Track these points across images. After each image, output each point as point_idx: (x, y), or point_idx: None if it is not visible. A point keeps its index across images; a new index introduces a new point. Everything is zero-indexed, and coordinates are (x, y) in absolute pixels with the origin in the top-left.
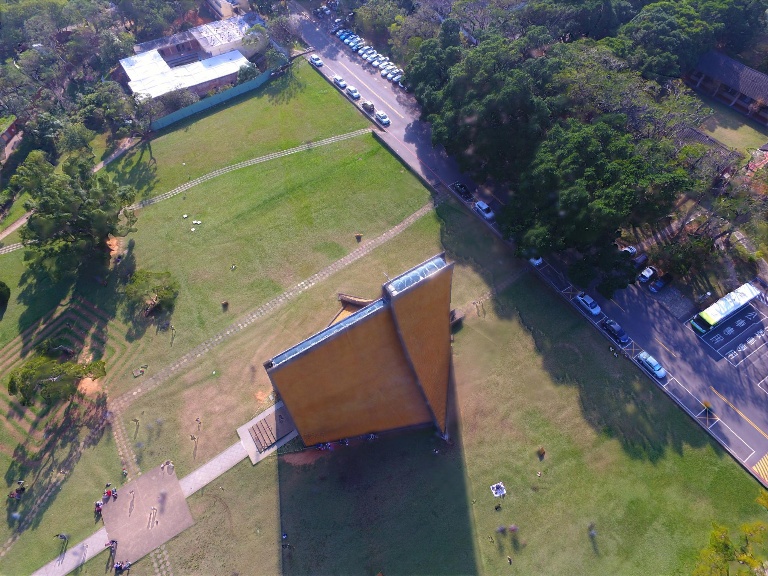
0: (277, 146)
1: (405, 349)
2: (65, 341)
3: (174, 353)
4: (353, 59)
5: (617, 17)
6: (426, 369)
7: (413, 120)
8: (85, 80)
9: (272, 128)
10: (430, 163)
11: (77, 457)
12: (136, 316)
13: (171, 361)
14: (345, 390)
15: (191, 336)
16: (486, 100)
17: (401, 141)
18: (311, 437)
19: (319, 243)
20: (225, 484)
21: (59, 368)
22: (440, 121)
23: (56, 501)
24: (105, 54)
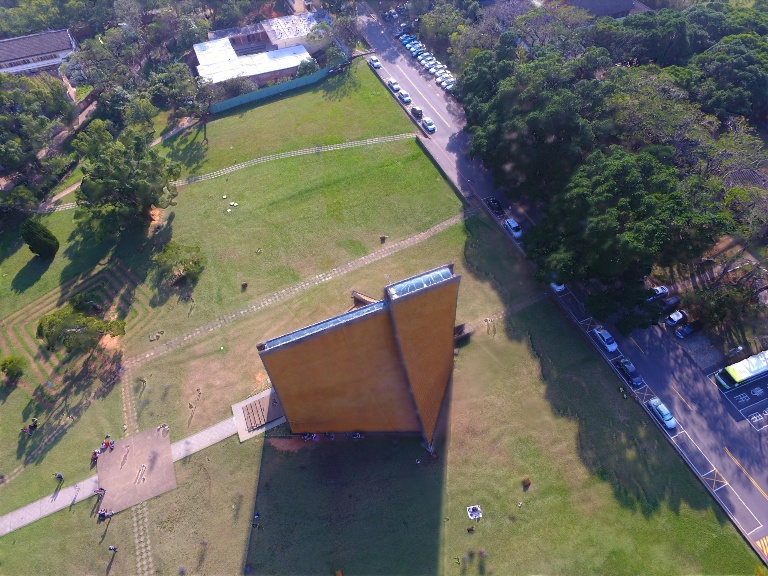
0: (322, 141)
1: (400, 354)
2: (97, 298)
3: (189, 324)
4: (411, 64)
5: (691, 46)
6: (421, 378)
7: (459, 130)
8: (159, 60)
9: (321, 123)
10: (468, 174)
11: (86, 406)
12: (163, 284)
13: (185, 331)
14: (336, 385)
15: (208, 310)
16: (529, 117)
17: (443, 149)
18: (298, 425)
19: (344, 239)
20: (211, 455)
21: (83, 321)
22: (481, 133)
23: (61, 442)
24: (181, 38)
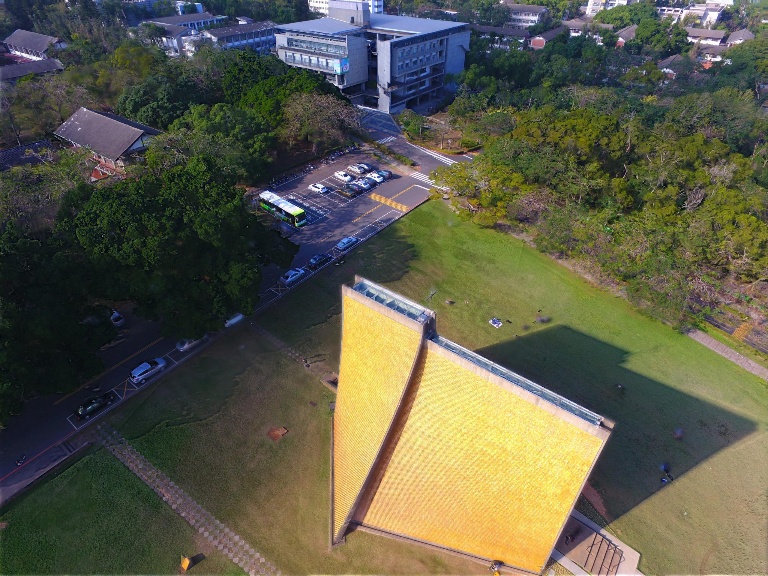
0: None
1: None
2: None
3: None
4: None
5: None
6: None
7: None
8: None
9: None
10: None
11: None
12: None
13: None
14: None
15: None
16: None
17: None
18: None
19: None
20: None
21: None
22: None
23: None
24: None
